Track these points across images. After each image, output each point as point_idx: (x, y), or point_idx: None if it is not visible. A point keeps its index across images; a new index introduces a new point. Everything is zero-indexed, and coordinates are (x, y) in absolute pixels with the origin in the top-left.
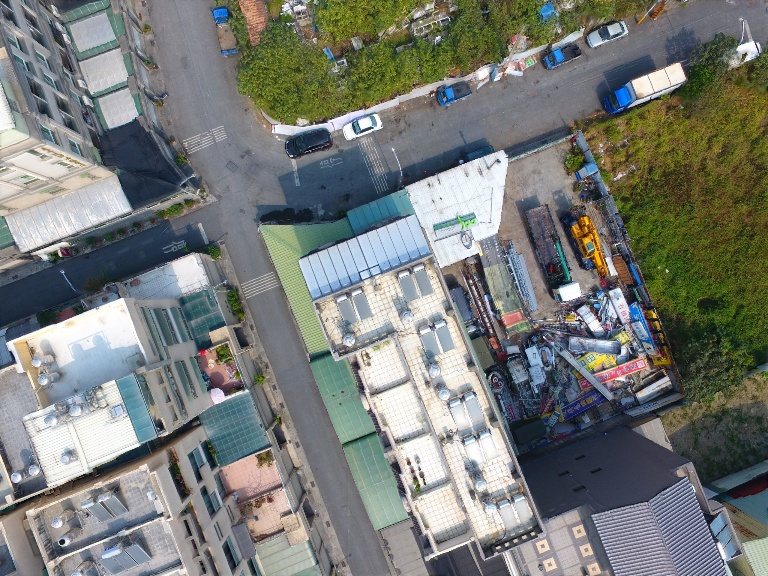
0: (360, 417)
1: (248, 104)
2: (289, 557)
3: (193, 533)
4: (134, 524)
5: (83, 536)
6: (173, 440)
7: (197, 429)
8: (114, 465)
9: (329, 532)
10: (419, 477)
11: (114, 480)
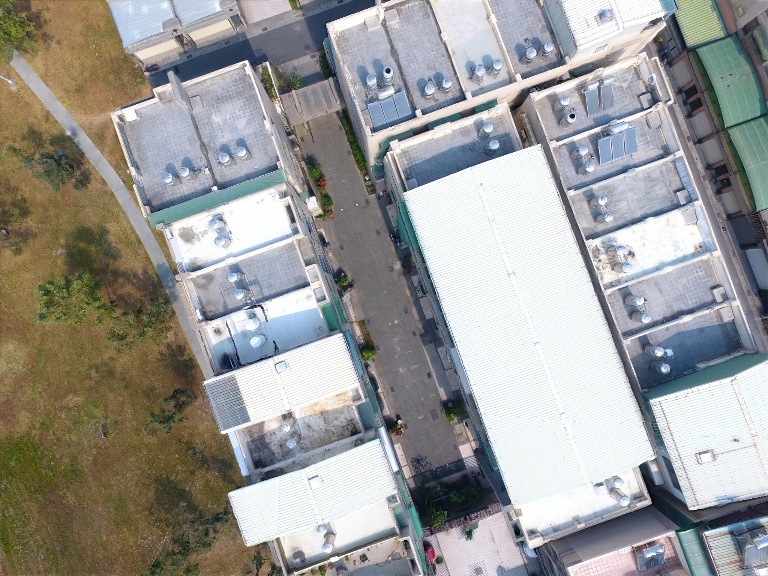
0: (746, 100)
1: None
2: None
3: None
4: None
5: (570, 129)
6: None
7: None
8: (592, 70)
9: None
10: None
11: (602, 76)
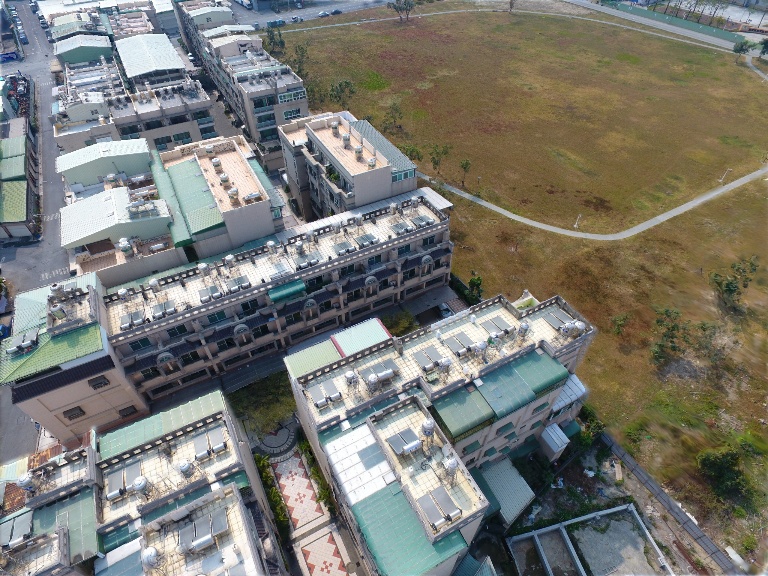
0: None
1: (15, 293)
2: None
3: None
4: None
5: None
6: None
7: None
8: None
9: None
10: None
11: None
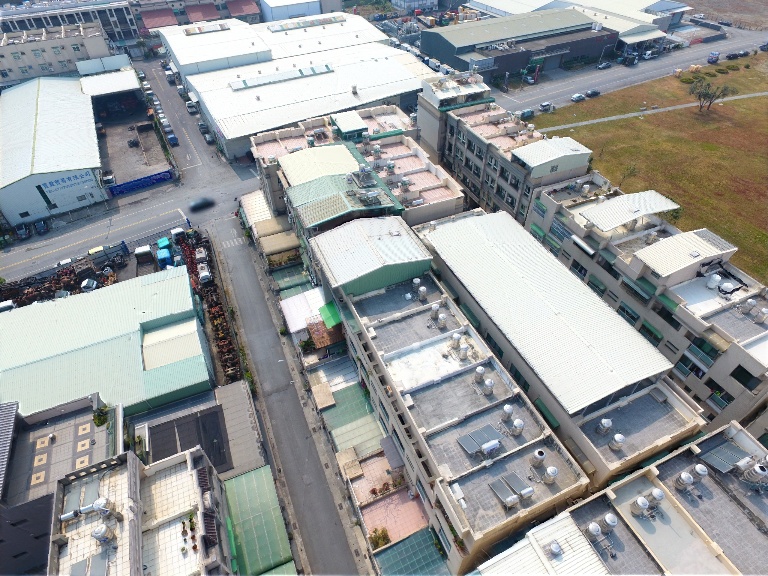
0: None
1: None
2: (355, 437)
3: (420, 465)
4: (481, 471)
5: (529, 458)
6: (469, 565)
7: (457, 575)
8: (519, 535)
9: (326, 458)
10: (188, 531)
11: None
